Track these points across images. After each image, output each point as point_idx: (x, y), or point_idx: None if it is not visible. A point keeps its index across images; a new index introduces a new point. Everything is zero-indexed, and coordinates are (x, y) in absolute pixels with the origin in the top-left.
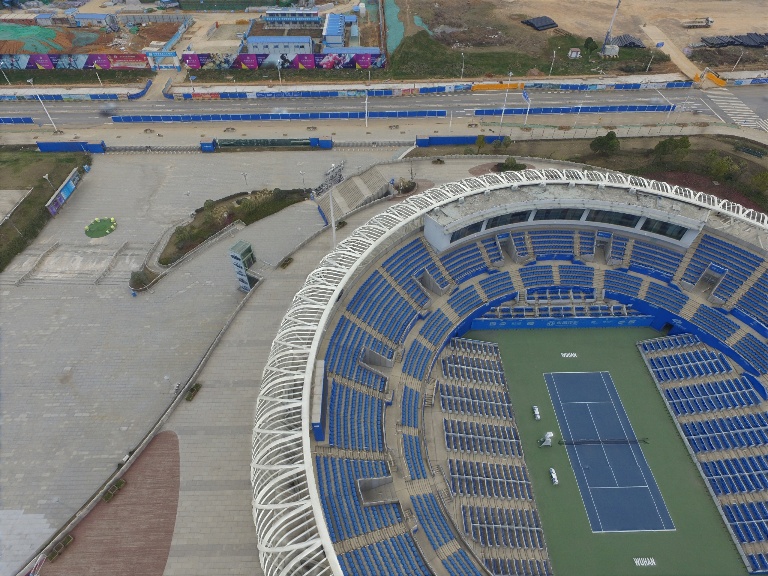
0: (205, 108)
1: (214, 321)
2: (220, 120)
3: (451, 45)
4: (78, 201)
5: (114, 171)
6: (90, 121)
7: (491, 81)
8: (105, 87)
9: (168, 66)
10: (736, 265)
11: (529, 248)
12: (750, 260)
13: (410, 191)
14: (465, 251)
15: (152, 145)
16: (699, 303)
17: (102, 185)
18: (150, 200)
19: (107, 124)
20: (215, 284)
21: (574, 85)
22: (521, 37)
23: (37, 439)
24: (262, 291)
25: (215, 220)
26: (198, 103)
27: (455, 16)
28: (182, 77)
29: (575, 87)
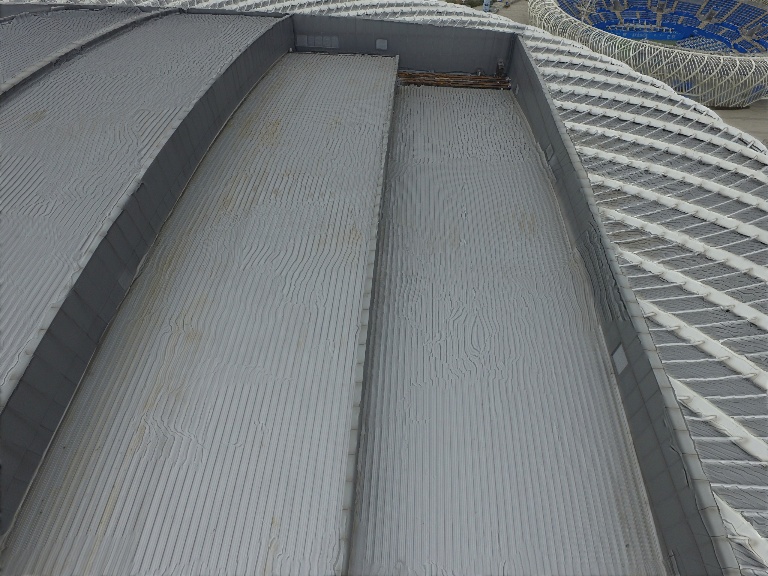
0: None
1: None
2: None
3: None
4: None
5: None
6: None
7: None
8: None
9: None
10: (726, 6)
11: (625, 4)
12: (732, 3)
13: None
14: None
15: None
16: (706, 23)
17: None
18: None
19: None
20: None
21: None
22: None
23: None
24: (500, 13)
25: None
26: None
27: None
28: None
29: None
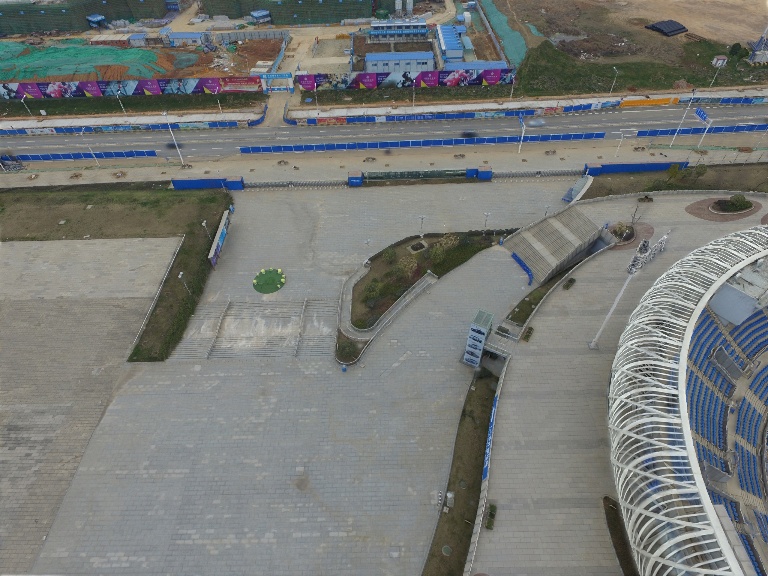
0: (334, 135)
1: (448, 404)
2: (355, 148)
3: (579, 56)
4: (233, 248)
5: (261, 211)
6: (215, 152)
7: (636, 95)
8: (218, 113)
9: (281, 88)
10: None
11: None
12: None
13: (631, 238)
14: (752, 321)
15: (291, 179)
16: None
17: (253, 228)
18: (312, 246)
19: (234, 155)
20: (431, 355)
21: (737, 99)
22: (651, 44)
23: (297, 569)
24: (514, 372)
25: (405, 273)
26: (324, 129)
27: (569, 23)
28: (297, 100)
29: (737, 101)
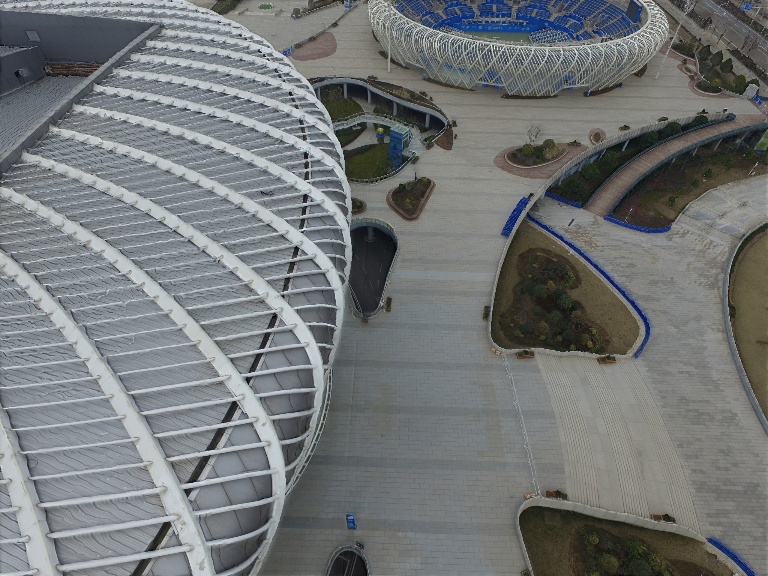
0: None
1: None
2: None
3: None
4: None
5: None
6: None
7: None
8: None
9: None
10: None
11: None
12: None
13: None
14: None
15: None
16: (557, 15)
17: None
18: None
19: None
20: (332, 18)
21: None
22: None
23: None
24: (358, 8)
25: None
26: None
27: None
28: None
29: None
